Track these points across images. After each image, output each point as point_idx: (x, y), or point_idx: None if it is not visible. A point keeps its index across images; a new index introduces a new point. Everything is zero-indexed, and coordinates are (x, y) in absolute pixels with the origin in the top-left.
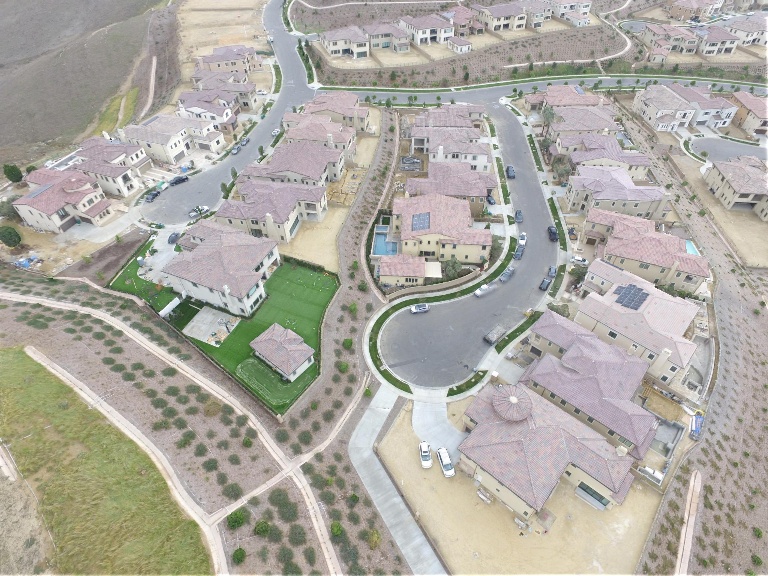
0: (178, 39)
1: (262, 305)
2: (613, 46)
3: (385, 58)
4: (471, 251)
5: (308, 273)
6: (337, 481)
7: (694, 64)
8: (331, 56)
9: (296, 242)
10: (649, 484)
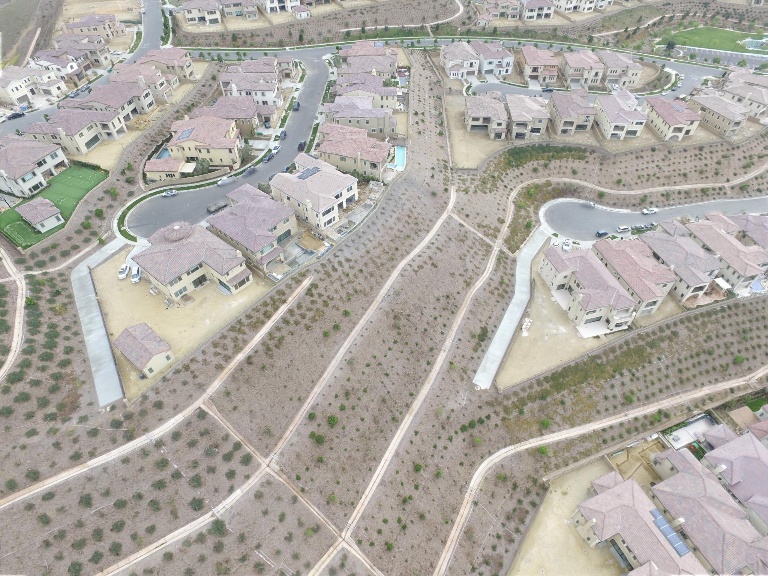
0: (60, 12)
1: (43, 191)
2: (444, 13)
3: (234, 24)
4: (222, 155)
5: (88, 171)
6: (50, 284)
7: (513, 27)
8: (188, 23)
9: (91, 153)
10: (269, 281)
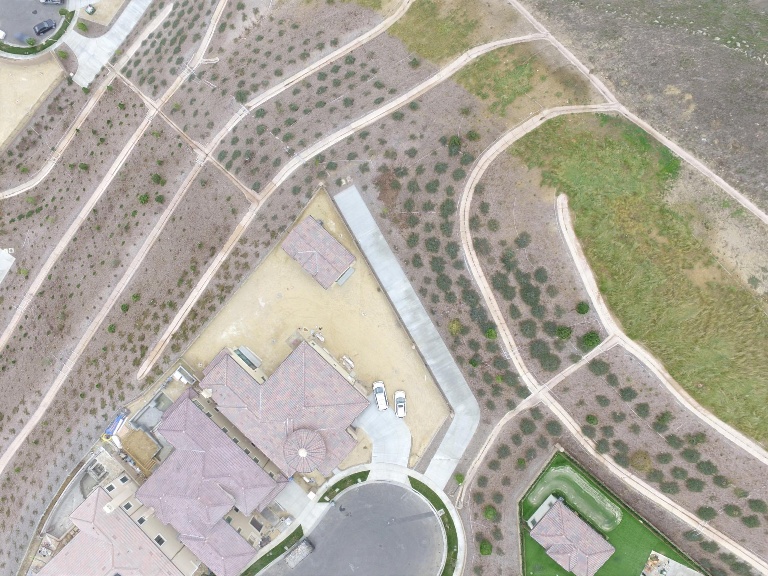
0: None
1: None
2: None
3: None
4: None
5: None
6: (491, 380)
7: None
8: None
9: None
10: (190, 367)
